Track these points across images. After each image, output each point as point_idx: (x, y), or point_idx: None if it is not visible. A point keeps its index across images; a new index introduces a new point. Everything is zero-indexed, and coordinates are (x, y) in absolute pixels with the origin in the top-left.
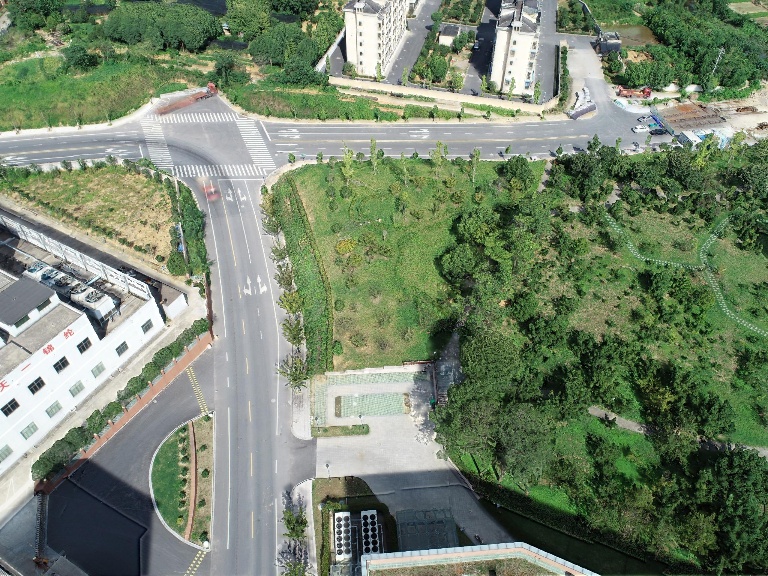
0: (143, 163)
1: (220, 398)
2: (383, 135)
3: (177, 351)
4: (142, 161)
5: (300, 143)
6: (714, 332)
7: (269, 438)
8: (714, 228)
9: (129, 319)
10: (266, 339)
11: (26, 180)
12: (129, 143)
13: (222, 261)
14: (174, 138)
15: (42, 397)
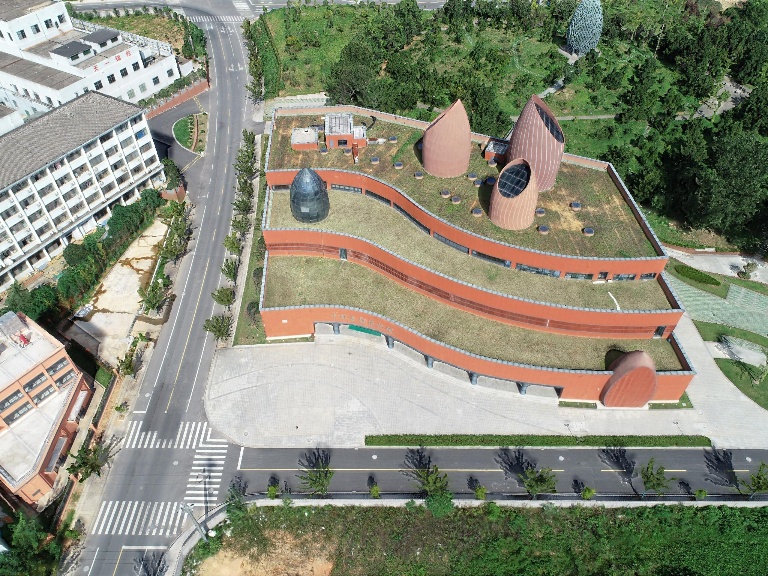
0: (166, 9)
1: (212, 108)
2: (330, 1)
3: (188, 82)
4: (166, 8)
5: (272, 6)
6: (506, 75)
7: (239, 122)
8: (529, 34)
9: (160, 62)
10: (241, 87)
11: (90, 21)
12: (156, 6)
13: (216, 57)
14: (187, 3)
15: (114, 88)
